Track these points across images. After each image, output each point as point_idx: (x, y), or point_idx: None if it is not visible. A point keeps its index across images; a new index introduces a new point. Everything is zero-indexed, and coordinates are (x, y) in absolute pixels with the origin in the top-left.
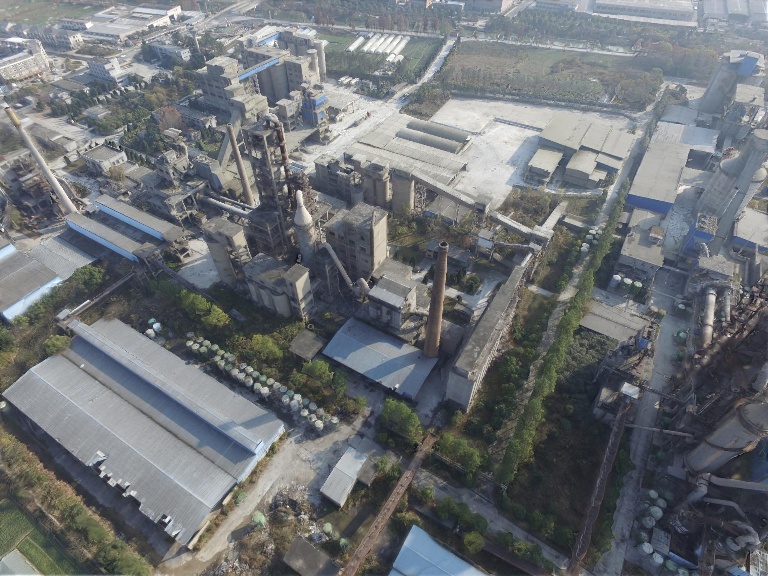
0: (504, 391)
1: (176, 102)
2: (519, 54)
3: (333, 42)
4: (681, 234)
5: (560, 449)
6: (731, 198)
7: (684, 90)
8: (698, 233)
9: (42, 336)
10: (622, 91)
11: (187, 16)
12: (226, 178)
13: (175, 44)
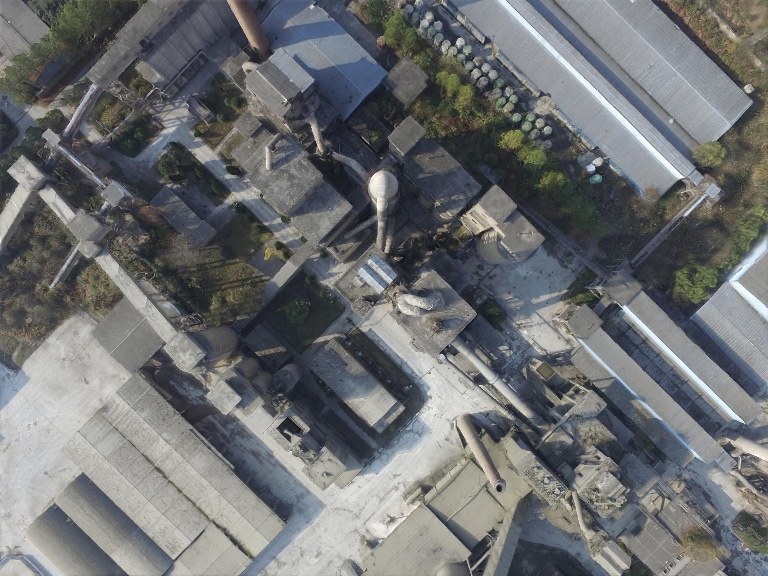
0: None
1: None
2: None
3: None
4: None
5: None
6: None
7: None
8: None
9: (731, 194)
10: None
11: None
12: (505, 478)
13: None
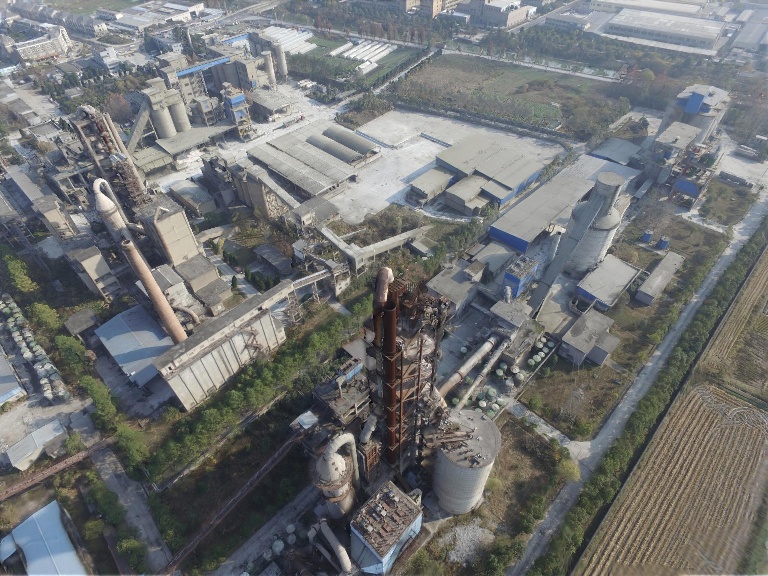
0: (224, 398)
1: None
2: (494, 71)
3: (321, 46)
4: None
5: (246, 465)
6: (555, 243)
7: (646, 124)
8: (507, 275)
9: None
10: (564, 118)
11: (207, 13)
12: None
13: (176, 38)
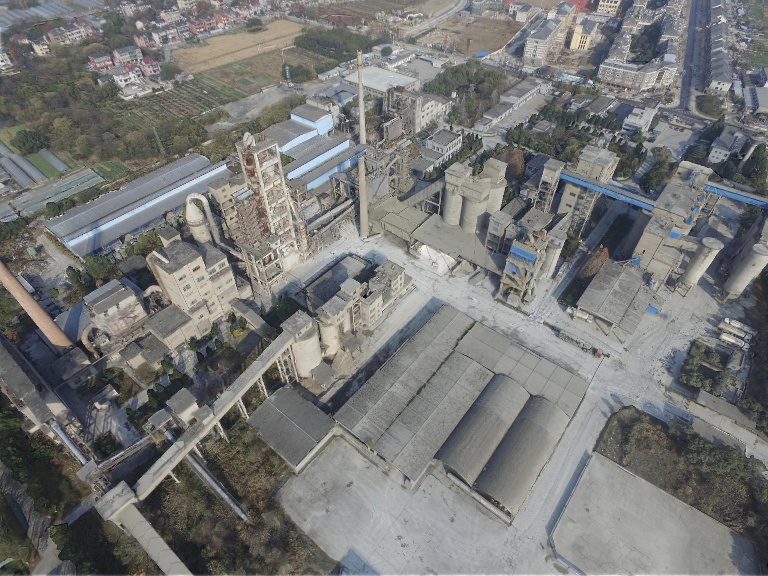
0: None
1: None
2: None
3: None
4: None
5: None
6: None
7: None
8: None
9: None
10: None
11: None
12: (389, 207)
13: None
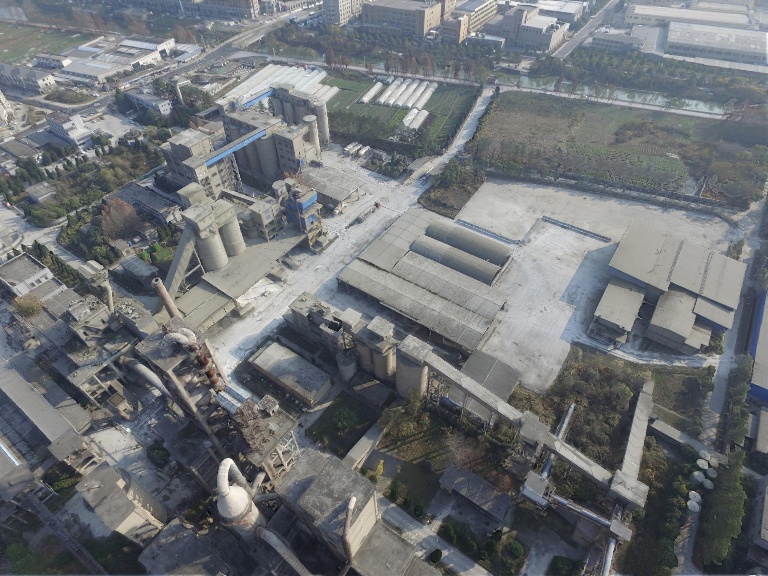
0: None
1: (141, 177)
2: (573, 112)
3: (345, 89)
4: None
5: None
6: None
7: None
8: None
9: None
10: (719, 184)
11: (180, 51)
12: None
13: (156, 91)
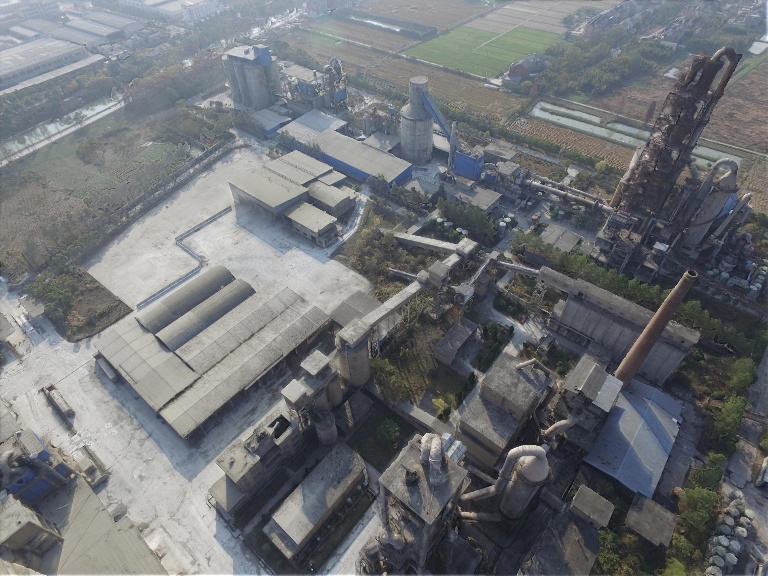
0: None
1: None
2: None
3: None
4: (432, 178)
5: None
6: None
7: (221, 103)
8: None
9: None
10: (210, 131)
11: None
12: None
13: None
